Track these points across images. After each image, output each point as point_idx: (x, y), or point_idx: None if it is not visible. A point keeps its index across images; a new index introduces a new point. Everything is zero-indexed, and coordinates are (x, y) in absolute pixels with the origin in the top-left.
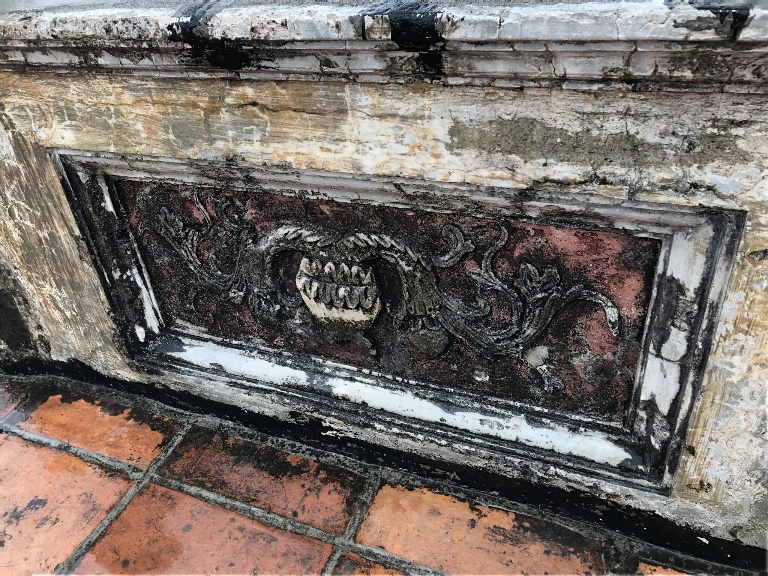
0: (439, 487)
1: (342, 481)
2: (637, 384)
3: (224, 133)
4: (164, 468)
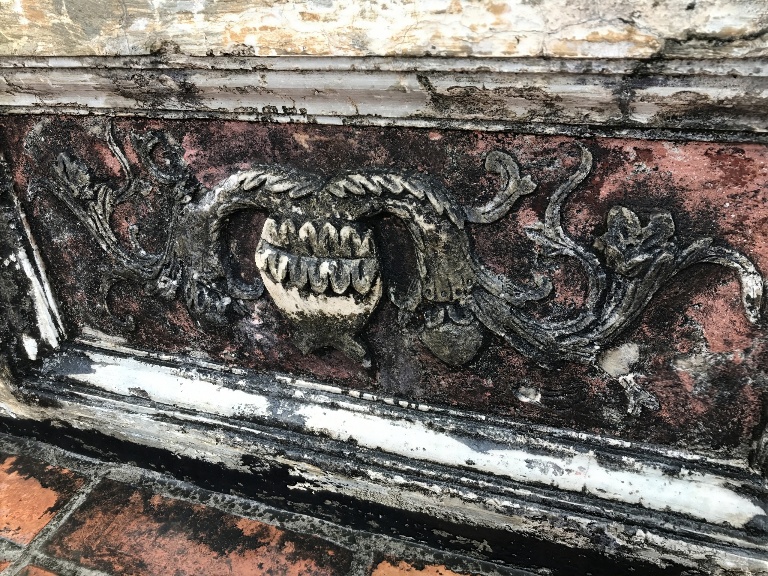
0: (461, 563)
1: (318, 557)
2: None
3: (147, 4)
4: (53, 543)
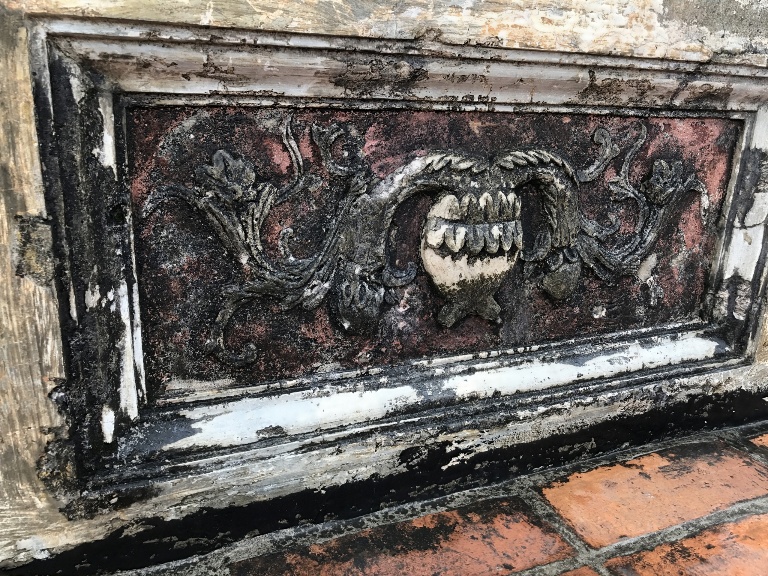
0: (582, 466)
1: (502, 510)
2: (718, 267)
3: None
4: None
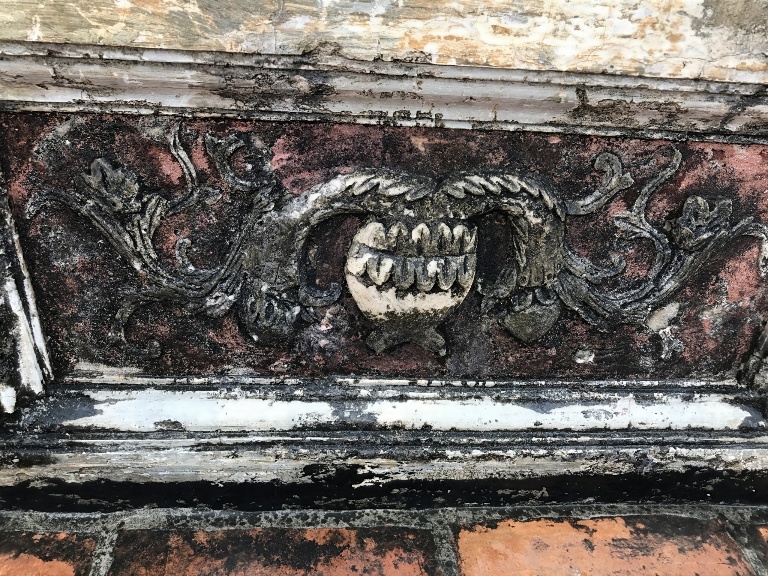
0: (523, 513)
1: (402, 544)
2: None
3: (314, 0)
4: None
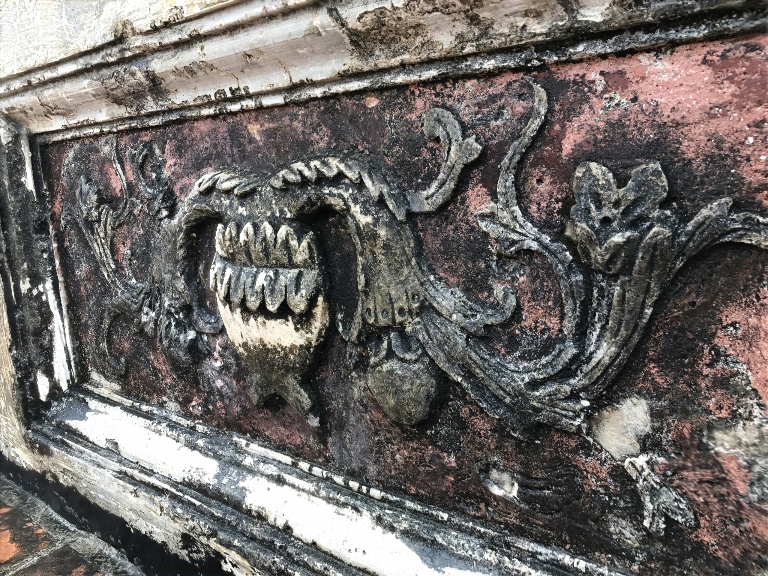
0: None
1: None
2: None
3: None
4: None
